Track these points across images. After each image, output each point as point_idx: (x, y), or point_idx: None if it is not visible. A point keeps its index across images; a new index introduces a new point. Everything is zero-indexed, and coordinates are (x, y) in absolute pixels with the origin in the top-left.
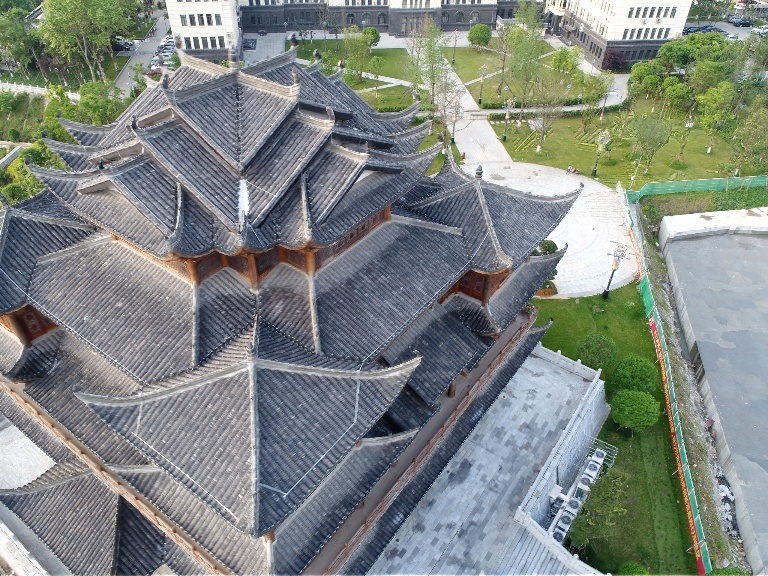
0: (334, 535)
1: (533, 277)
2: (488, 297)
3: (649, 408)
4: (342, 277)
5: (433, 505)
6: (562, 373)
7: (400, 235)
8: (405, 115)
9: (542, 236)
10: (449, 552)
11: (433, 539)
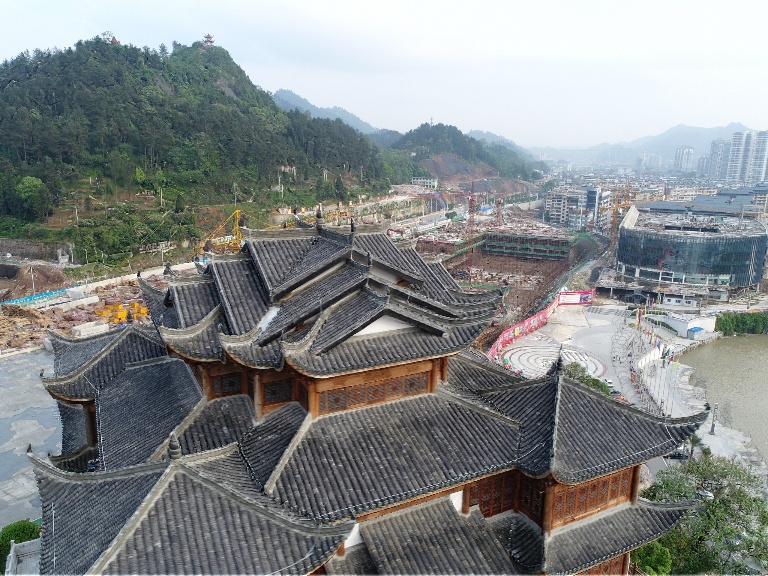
0: None
1: None
2: None
3: (25, 521)
4: None
5: None
6: (25, 575)
7: None
8: None
9: None
10: None
11: None
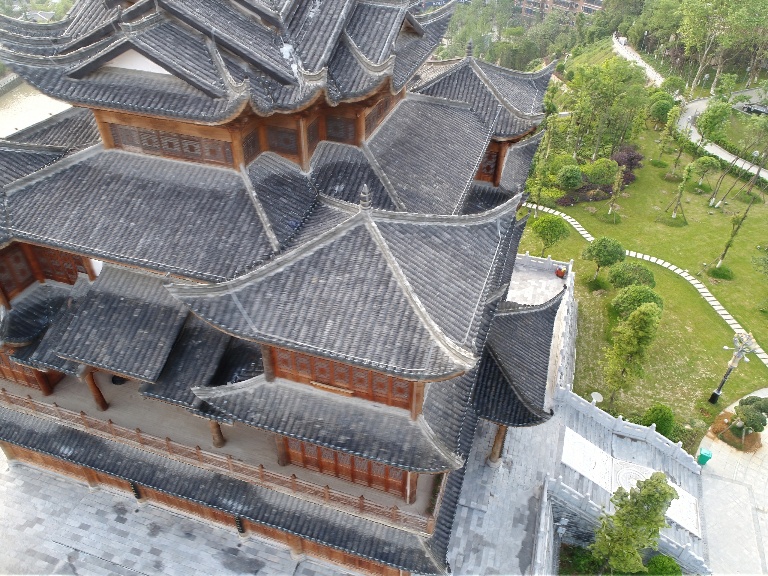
0: (13, 382)
1: (391, 441)
2: (265, 366)
3: None
4: (119, 169)
5: (187, 538)
6: None
7: (222, 190)
8: (380, 71)
9: (339, 353)
10: (125, 573)
11: (139, 549)
